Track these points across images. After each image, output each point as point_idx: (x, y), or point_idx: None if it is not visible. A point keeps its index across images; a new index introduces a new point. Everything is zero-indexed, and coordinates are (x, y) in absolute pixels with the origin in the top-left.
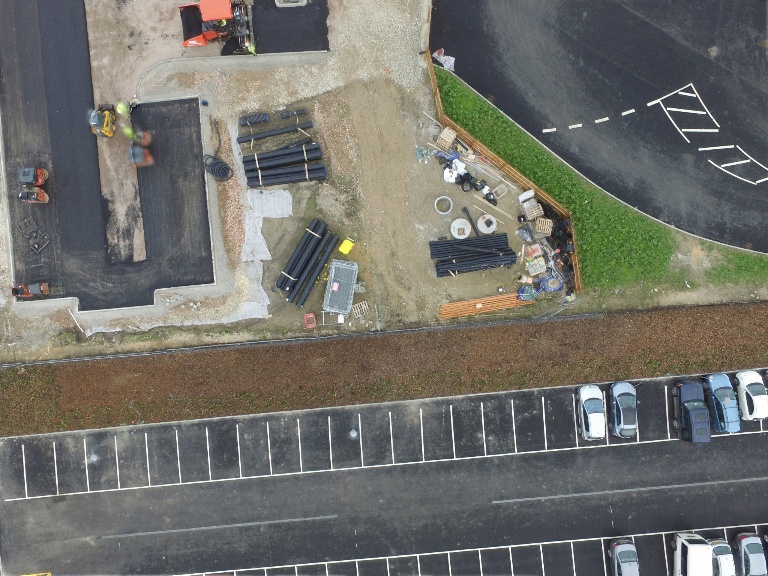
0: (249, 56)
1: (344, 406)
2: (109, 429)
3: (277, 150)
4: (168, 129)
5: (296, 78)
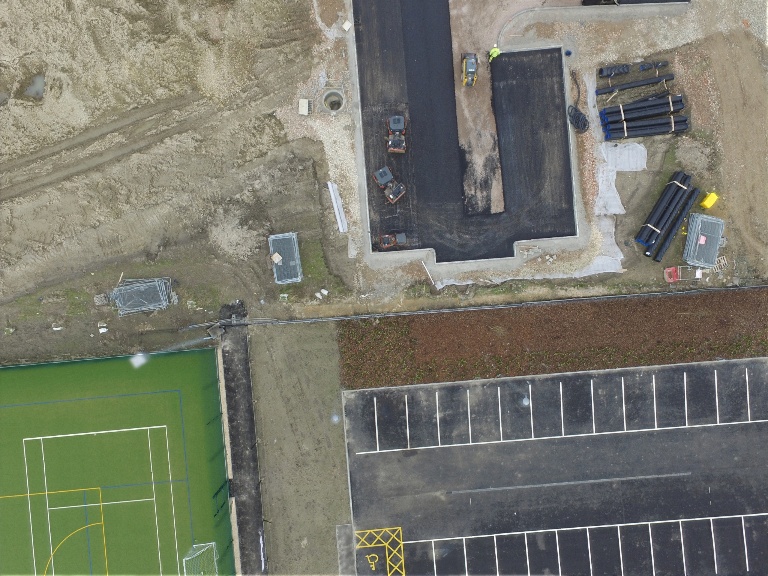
0: (613, 6)
1: (701, 362)
2: (462, 383)
3: (640, 102)
4: (529, 79)
5: (656, 30)
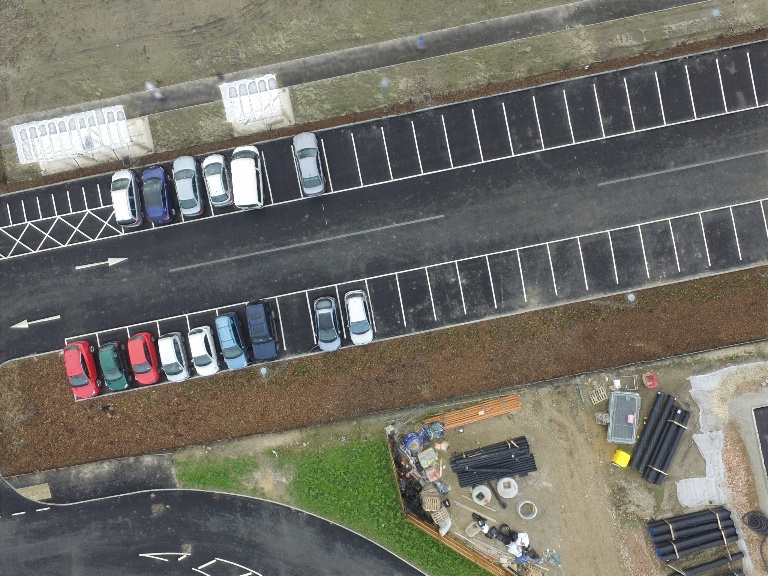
0: None
1: (604, 296)
2: None
3: None
4: None
5: None
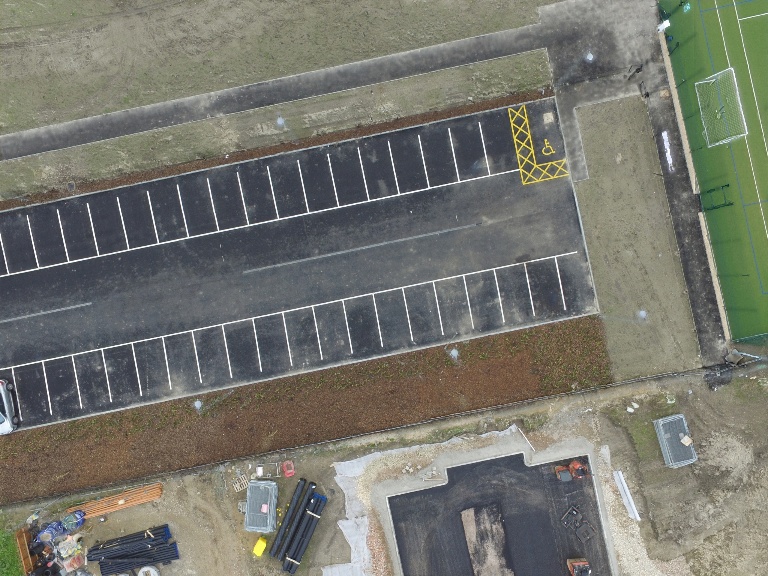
0: None
1: (247, 384)
2: (480, 335)
3: None
4: None
5: None
